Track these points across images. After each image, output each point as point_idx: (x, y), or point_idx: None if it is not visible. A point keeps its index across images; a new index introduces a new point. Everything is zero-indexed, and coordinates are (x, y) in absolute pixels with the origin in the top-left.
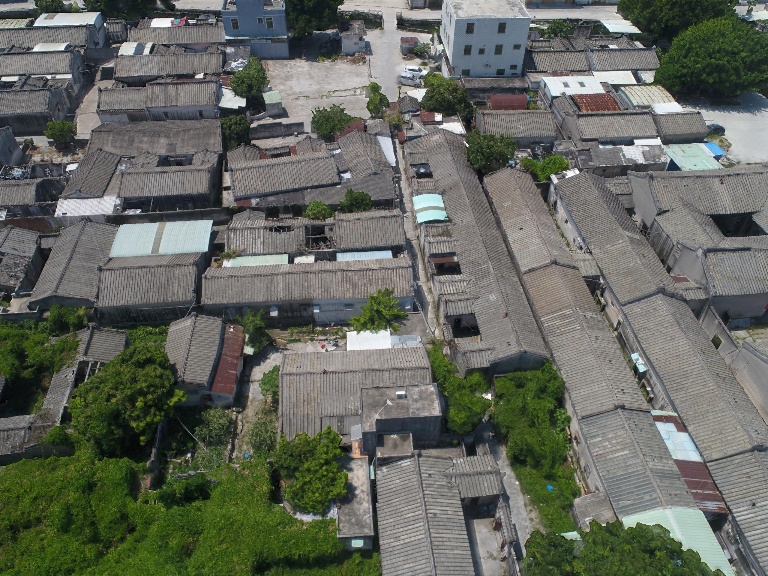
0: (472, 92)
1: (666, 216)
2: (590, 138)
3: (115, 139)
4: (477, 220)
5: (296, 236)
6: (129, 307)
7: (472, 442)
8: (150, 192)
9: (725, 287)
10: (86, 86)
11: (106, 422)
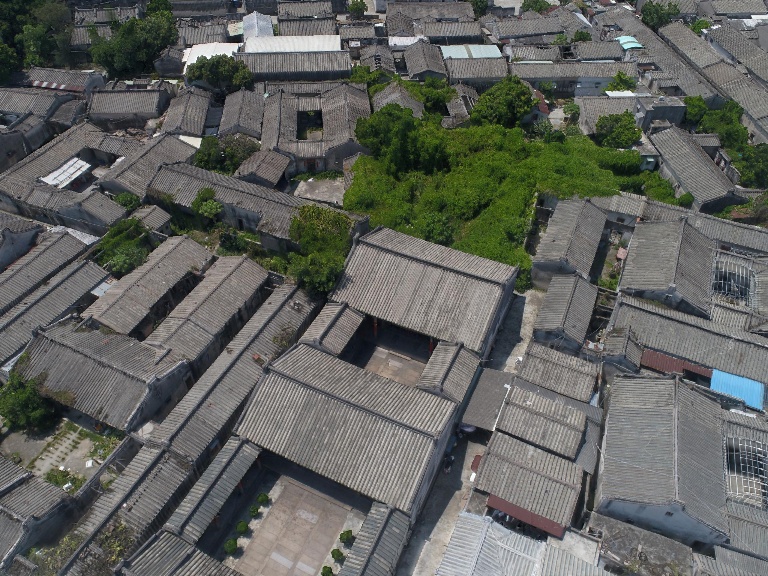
0: None
1: None
2: (722, 13)
3: (404, 9)
4: (664, 46)
5: (554, 51)
6: (469, 80)
7: (695, 132)
8: (445, 34)
9: None
10: None
11: (506, 106)
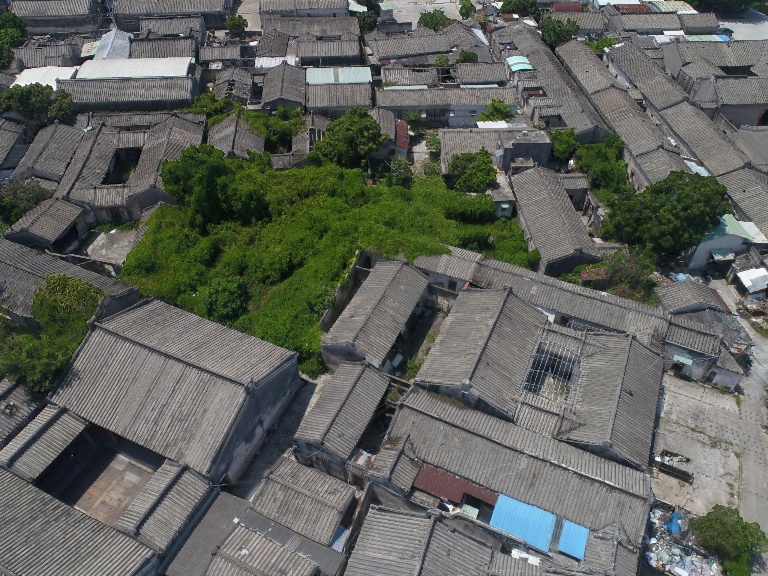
0: (536, 6)
1: (689, 66)
2: (631, 29)
3: (282, 25)
4: (555, 68)
5: (431, 74)
6: (328, 109)
7: (567, 171)
8: (319, 54)
9: (729, 99)
10: (236, 2)
11: (346, 144)
